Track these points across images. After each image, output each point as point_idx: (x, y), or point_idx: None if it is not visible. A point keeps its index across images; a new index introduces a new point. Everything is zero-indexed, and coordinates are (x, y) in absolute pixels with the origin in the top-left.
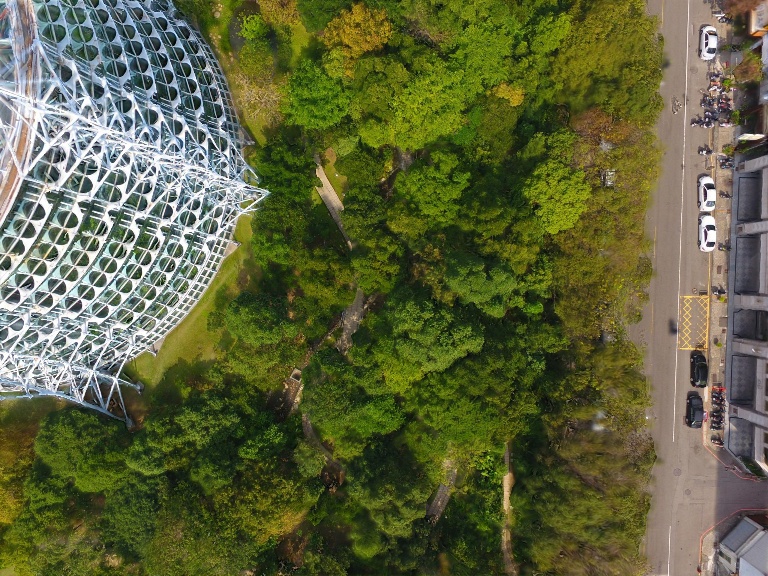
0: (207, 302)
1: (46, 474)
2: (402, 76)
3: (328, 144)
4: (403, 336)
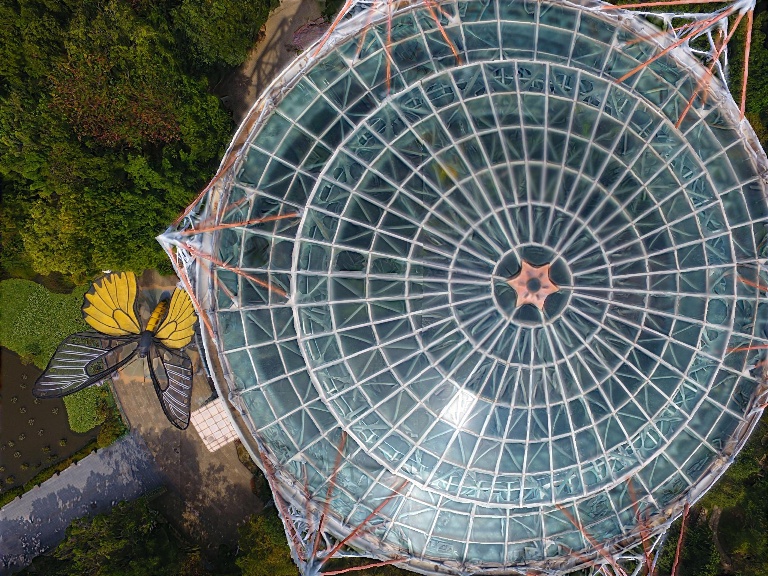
0: None
1: None
2: None
3: None
4: None
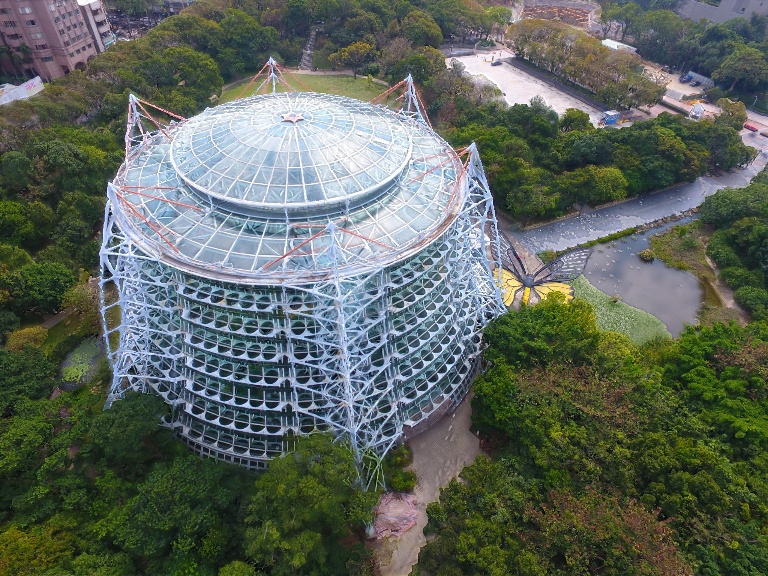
0: None
1: None
2: None
3: None
4: (78, 158)
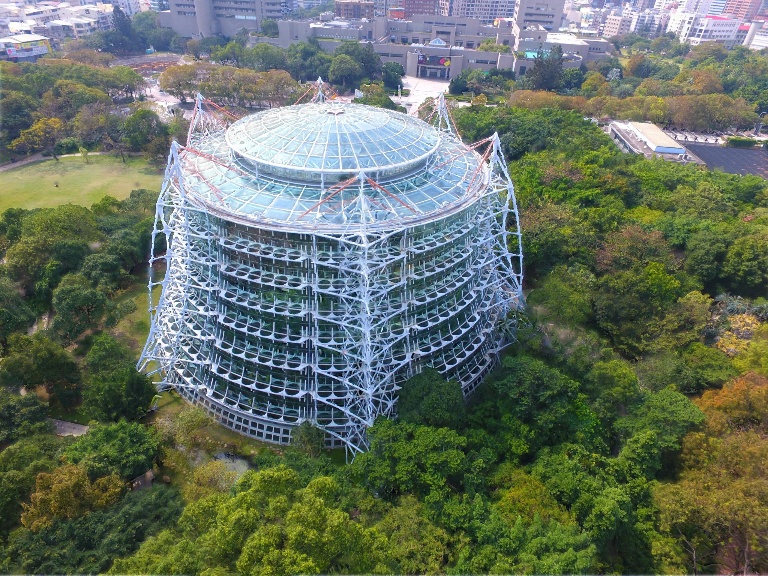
0: None
1: None
2: None
3: None
4: None
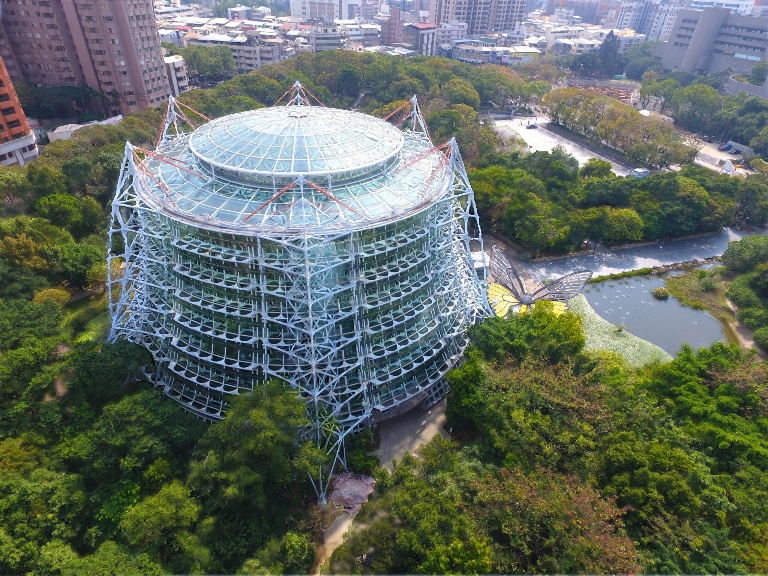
0: None
1: None
2: None
3: None
4: None
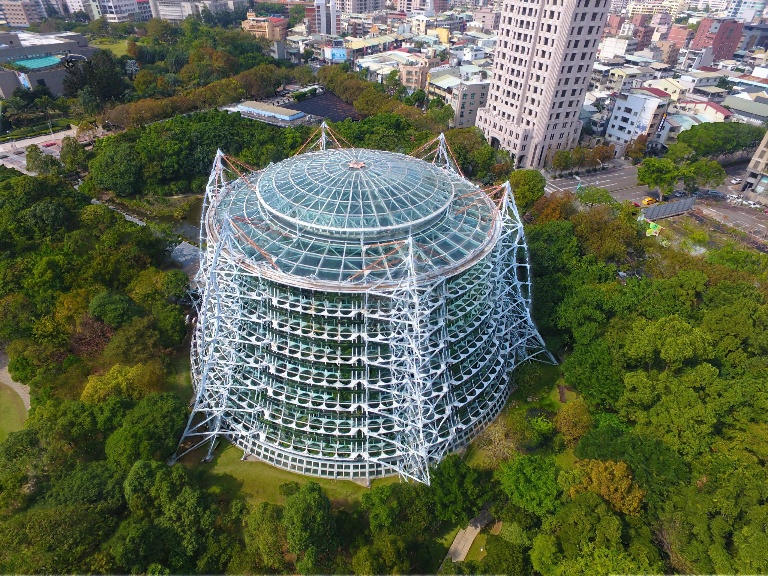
0: (304, 482)
1: (127, 407)
2: (613, 534)
3: (503, 515)
4: None
